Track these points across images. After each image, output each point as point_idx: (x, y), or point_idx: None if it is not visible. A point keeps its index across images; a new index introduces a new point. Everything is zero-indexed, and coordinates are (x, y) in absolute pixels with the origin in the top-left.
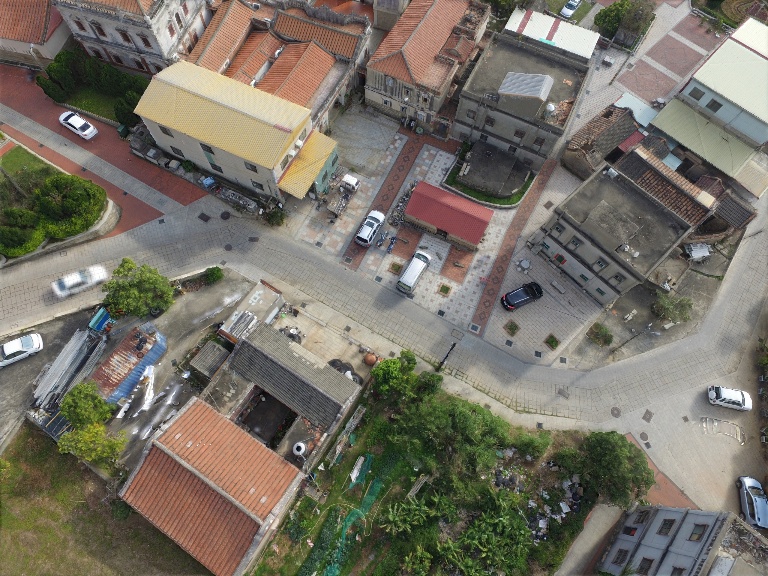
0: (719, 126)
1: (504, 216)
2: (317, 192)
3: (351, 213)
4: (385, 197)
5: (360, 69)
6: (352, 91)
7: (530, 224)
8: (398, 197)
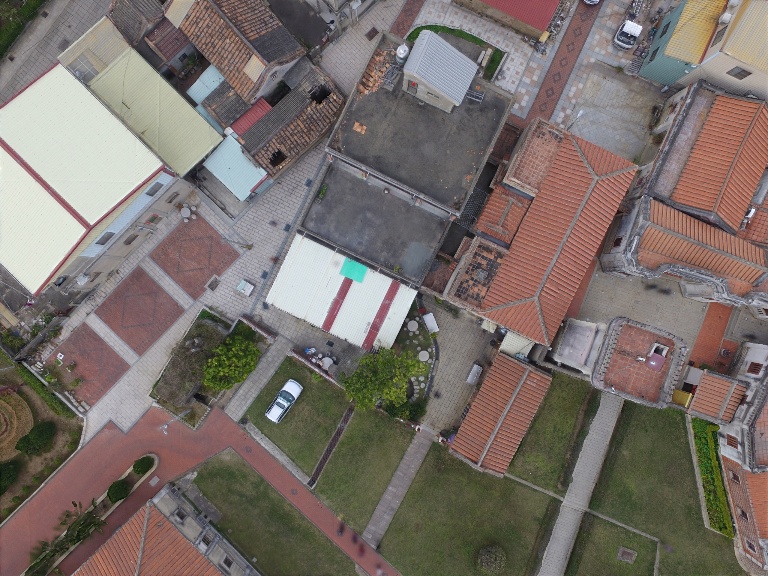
0: (129, 126)
1: (431, 14)
2: (673, 8)
3: (619, 8)
4: (578, 33)
5: (629, 203)
6: (624, 197)
7: (399, 5)
8: (562, 34)
